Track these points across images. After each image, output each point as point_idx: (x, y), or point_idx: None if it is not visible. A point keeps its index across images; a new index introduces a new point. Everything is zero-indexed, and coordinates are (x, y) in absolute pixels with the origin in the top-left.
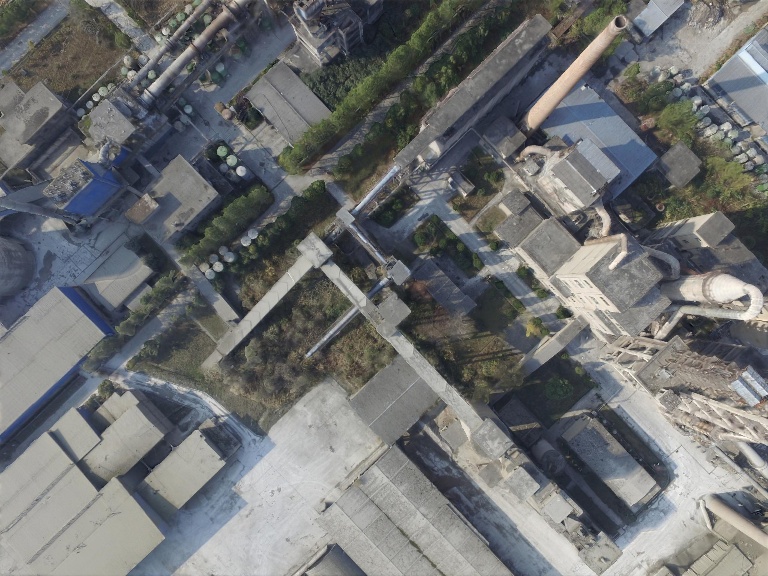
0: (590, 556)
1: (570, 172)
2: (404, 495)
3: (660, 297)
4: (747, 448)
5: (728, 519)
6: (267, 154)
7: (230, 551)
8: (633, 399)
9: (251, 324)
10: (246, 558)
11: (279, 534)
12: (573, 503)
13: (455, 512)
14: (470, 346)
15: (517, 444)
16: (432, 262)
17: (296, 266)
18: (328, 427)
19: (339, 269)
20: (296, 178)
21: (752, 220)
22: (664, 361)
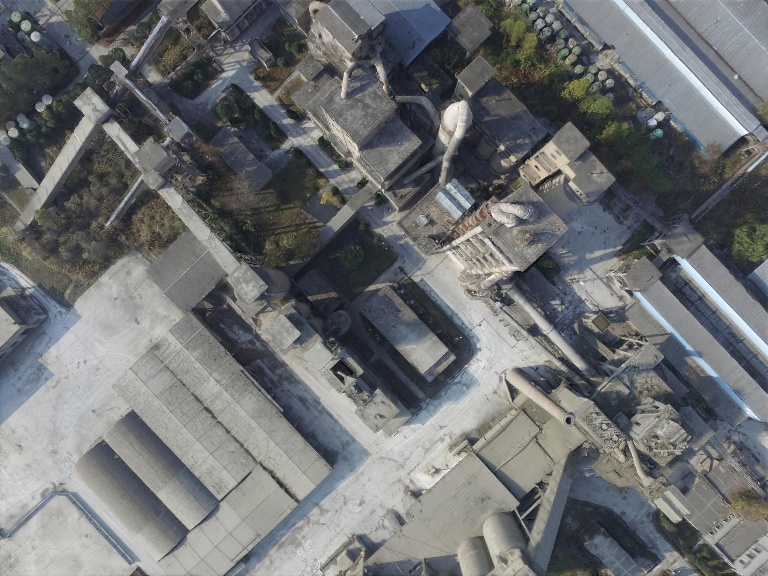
0: (366, 413)
1: (332, 18)
2: (197, 361)
3: (410, 137)
4: (532, 311)
5: (515, 384)
6: (72, 26)
7: (37, 422)
8: (436, 272)
9: (47, 190)
10: (53, 429)
11: (85, 405)
12: (353, 362)
13: (249, 378)
14: (273, 218)
15: (318, 316)
16: (227, 129)
17: (80, 126)
18: (133, 299)
19: (119, 126)
20: (100, 50)
21: (550, 87)
22: (426, 209)
